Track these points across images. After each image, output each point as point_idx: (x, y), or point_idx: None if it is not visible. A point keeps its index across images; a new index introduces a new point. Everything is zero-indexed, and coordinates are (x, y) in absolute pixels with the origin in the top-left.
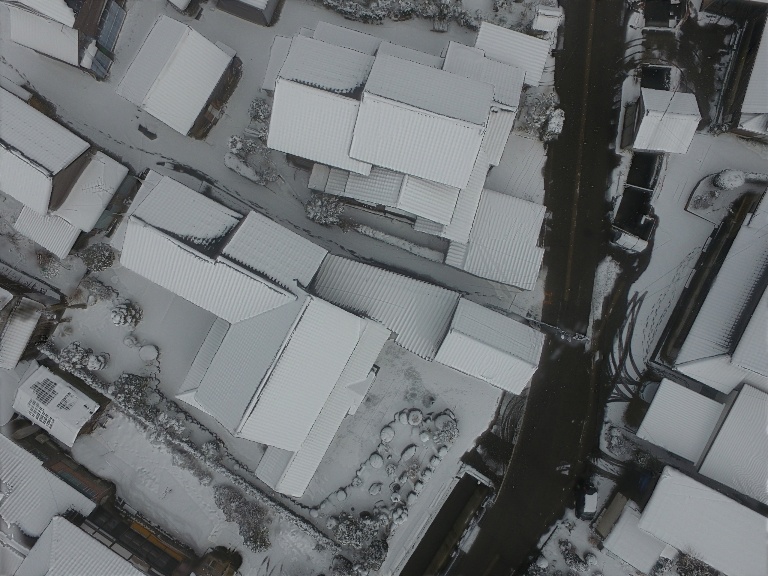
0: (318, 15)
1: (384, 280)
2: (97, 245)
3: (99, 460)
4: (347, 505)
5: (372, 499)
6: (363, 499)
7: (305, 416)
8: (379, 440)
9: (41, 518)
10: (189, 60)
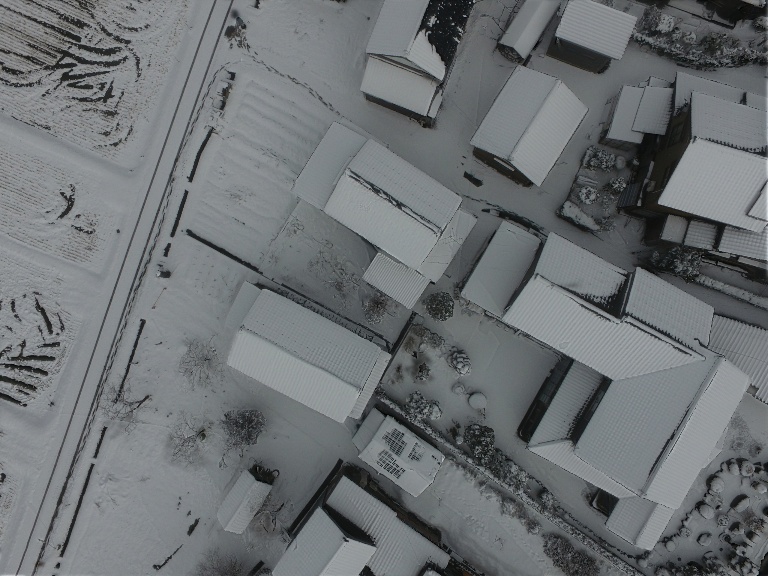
0: (650, 62)
1: (745, 334)
2: (440, 294)
3: (428, 508)
4: (673, 555)
5: (700, 549)
6: (691, 549)
7: (691, 474)
8: (705, 490)
9: (405, 571)
10: (554, 112)
